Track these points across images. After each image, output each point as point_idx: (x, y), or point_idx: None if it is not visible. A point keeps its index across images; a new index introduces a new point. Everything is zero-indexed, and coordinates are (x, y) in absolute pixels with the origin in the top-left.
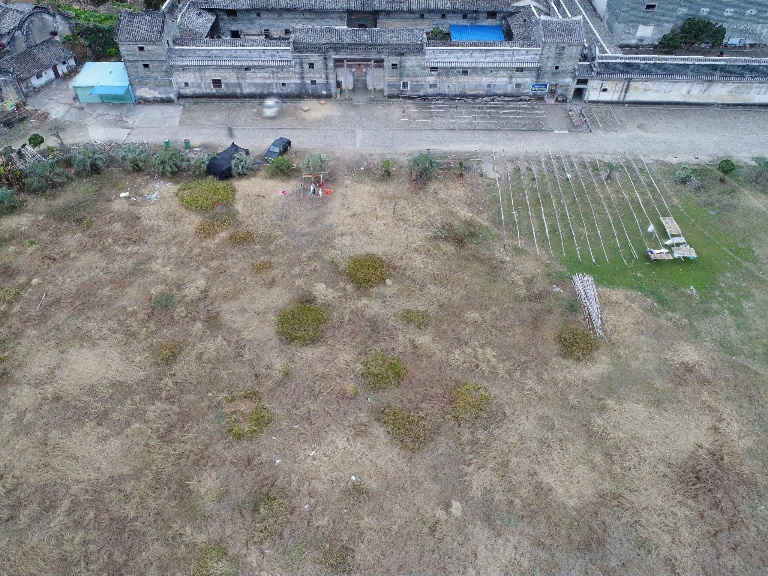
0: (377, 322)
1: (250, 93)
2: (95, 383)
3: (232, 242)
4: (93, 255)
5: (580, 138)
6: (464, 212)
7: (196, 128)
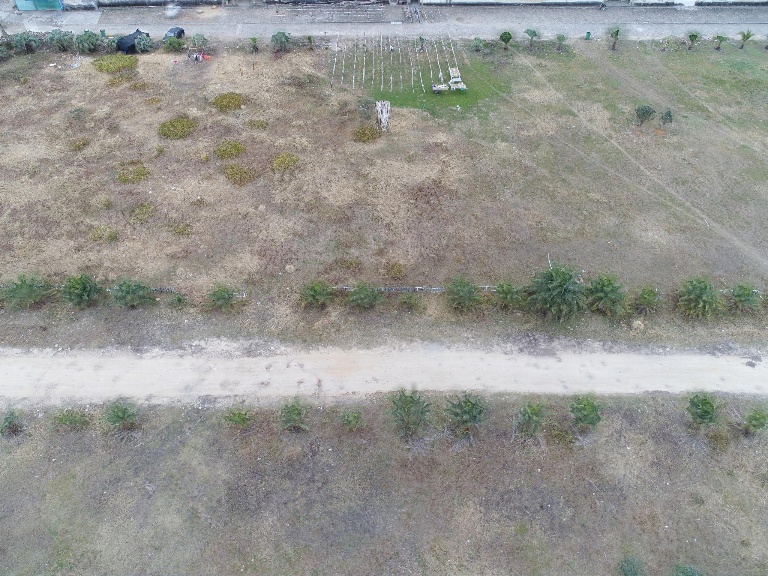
0: (230, 127)
1: (156, 1)
2: (28, 160)
3: (132, 88)
4: (28, 97)
5: (409, 26)
6: (308, 69)
7: (111, 25)
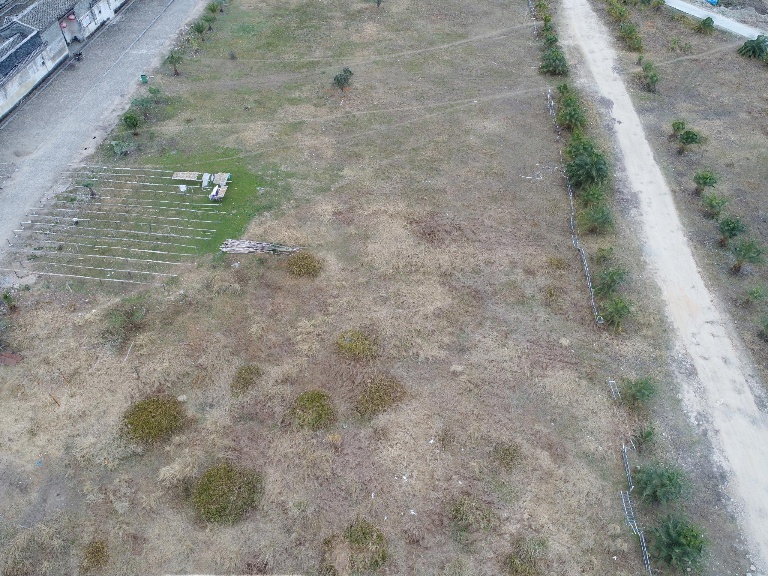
0: (241, 414)
1: None
2: None
3: None
4: None
5: (8, 198)
6: (88, 315)
7: None
